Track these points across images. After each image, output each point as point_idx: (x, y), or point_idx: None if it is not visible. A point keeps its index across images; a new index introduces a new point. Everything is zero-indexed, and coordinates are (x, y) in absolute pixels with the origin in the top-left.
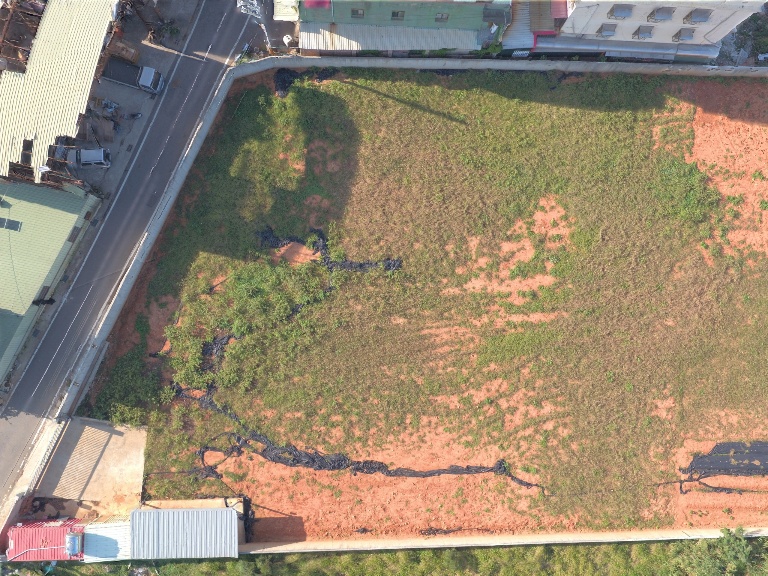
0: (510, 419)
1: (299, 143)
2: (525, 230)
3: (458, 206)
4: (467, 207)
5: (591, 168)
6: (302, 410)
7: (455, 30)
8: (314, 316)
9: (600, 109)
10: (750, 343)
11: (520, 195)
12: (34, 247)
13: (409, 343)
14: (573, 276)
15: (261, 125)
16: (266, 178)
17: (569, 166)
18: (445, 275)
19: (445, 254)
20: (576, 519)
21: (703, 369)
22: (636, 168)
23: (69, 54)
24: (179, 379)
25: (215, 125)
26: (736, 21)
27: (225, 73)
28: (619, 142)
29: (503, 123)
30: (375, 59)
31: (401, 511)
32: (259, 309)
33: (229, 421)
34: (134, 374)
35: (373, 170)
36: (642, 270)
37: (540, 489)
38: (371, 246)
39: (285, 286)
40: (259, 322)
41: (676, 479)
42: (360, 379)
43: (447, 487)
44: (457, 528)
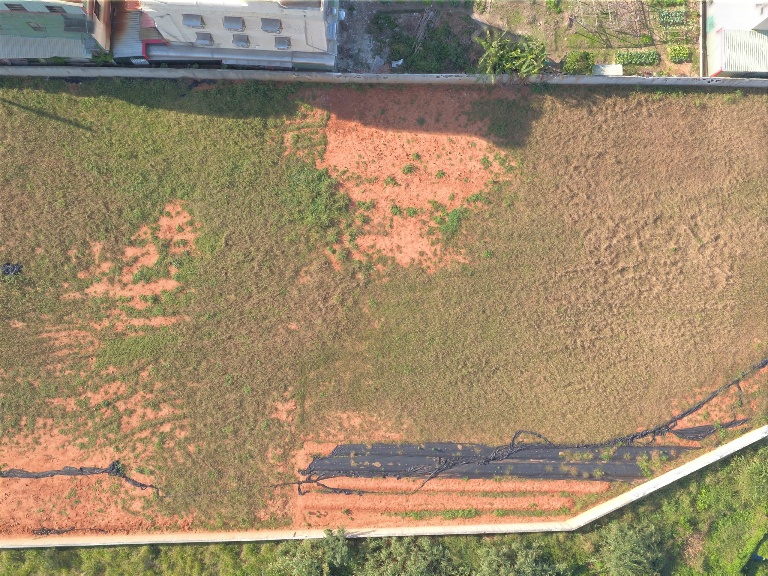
0: (127, 421)
1: None
2: (149, 235)
3: (80, 212)
4: (90, 213)
5: (217, 174)
6: None
7: (62, 39)
8: None
9: (229, 116)
10: (374, 346)
11: (145, 201)
12: None
13: (26, 346)
14: (195, 280)
15: None
16: None
17: (196, 172)
18: (66, 279)
19: (66, 259)
20: (190, 519)
21: (326, 372)
22: (264, 174)
23: None
24: None
25: None
26: (319, 30)
27: None
28: (248, 148)
29: (130, 130)
30: None
31: (13, 511)
32: None
33: None
34: None
35: None
36: (265, 274)
37: (155, 490)
38: None
39: None
40: None
41: (294, 480)
42: None
43: (60, 488)
44: (69, 528)
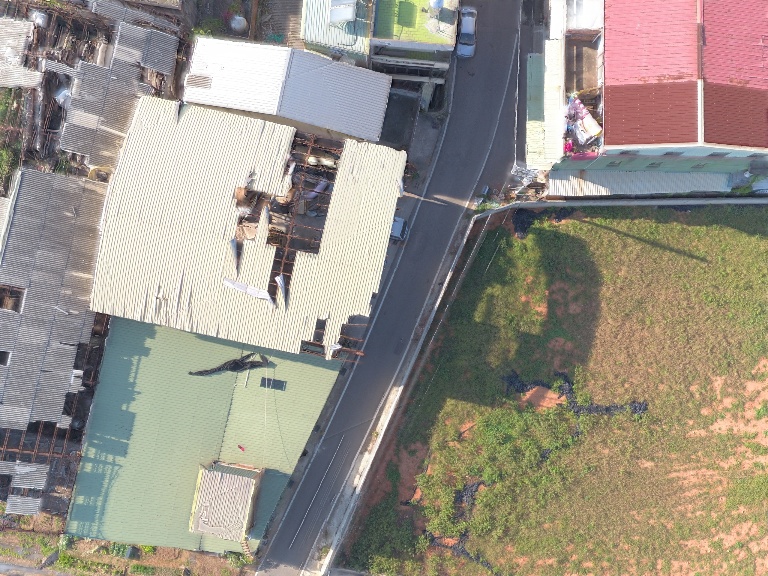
0: (761, 563)
1: (540, 285)
2: None
3: (702, 346)
4: (711, 347)
5: None
6: (554, 558)
7: (706, 173)
8: (563, 462)
9: None
10: None
11: (764, 333)
12: (298, 406)
13: (658, 487)
14: None
15: (503, 268)
16: (510, 322)
17: None
18: (691, 417)
19: (691, 395)
20: None
21: None
22: None
23: (361, 233)
24: (433, 529)
25: (456, 268)
26: None
27: (473, 221)
28: None
29: (744, 259)
30: (619, 201)
31: None
32: (510, 457)
33: (481, 569)
34: (388, 524)
35: (616, 311)
36: None
37: None
38: (616, 388)
39: (532, 431)
40: (509, 469)
41: None
42: (610, 525)
43: None
44: None
